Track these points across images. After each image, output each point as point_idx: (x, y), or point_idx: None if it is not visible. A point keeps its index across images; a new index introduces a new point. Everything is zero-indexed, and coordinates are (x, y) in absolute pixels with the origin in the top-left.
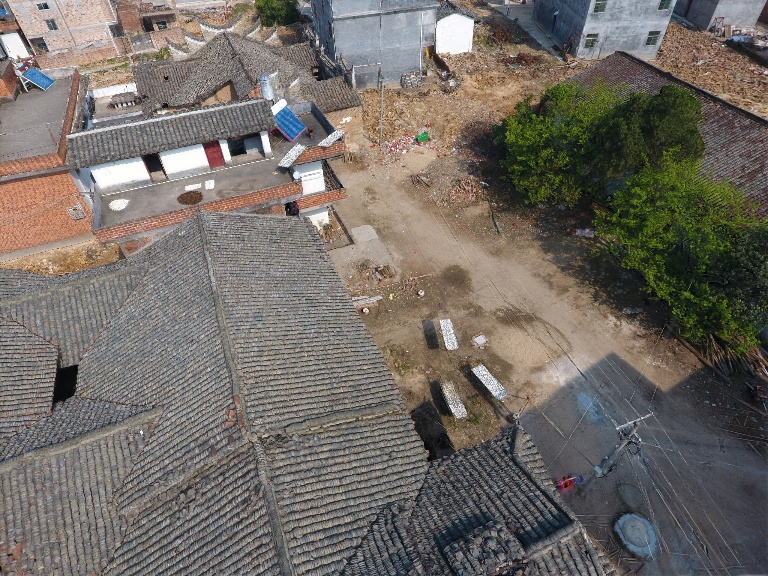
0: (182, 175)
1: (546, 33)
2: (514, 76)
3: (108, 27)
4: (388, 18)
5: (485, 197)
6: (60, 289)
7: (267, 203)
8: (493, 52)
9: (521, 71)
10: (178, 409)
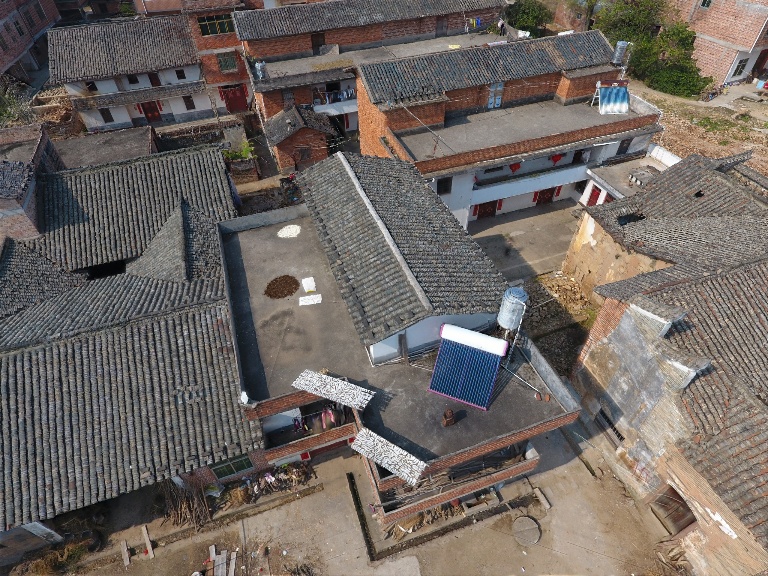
0: None
1: None
2: None
3: None
4: None
5: None
6: None
7: None
8: None
9: None
10: None
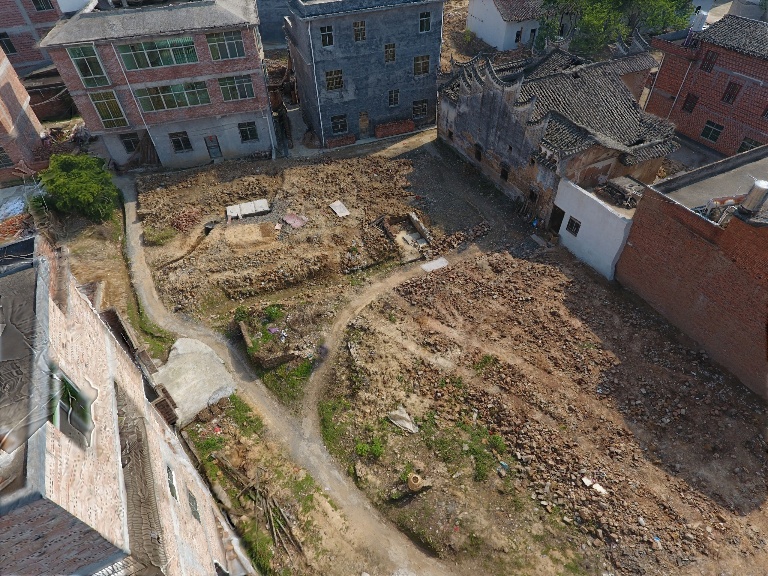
0: None
1: None
2: None
3: None
4: None
5: None
6: None
7: None
8: None
9: None
10: None
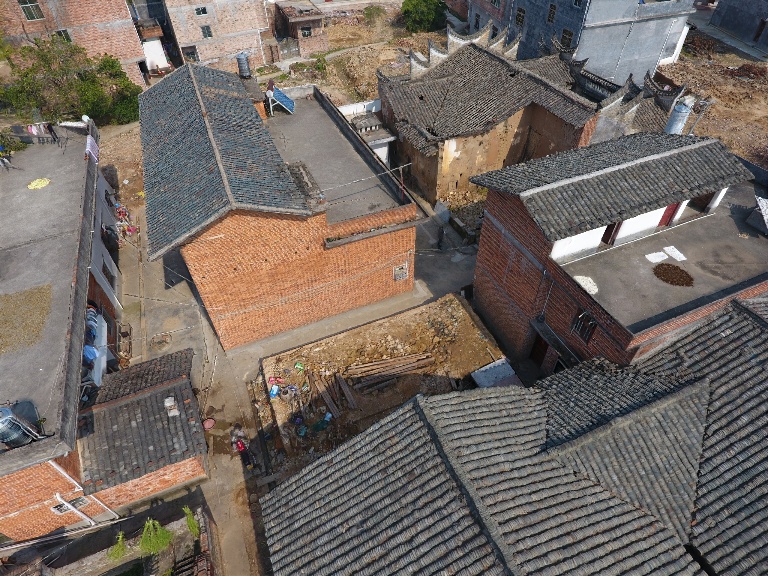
0: (627, 239)
1: (743, 41)
2: (759, 91)
3: (259, 34)
4: (638, 26)
5: None
6: (620, 425)
7: None
8: (703, 63)
9: (761, 85)
10: None
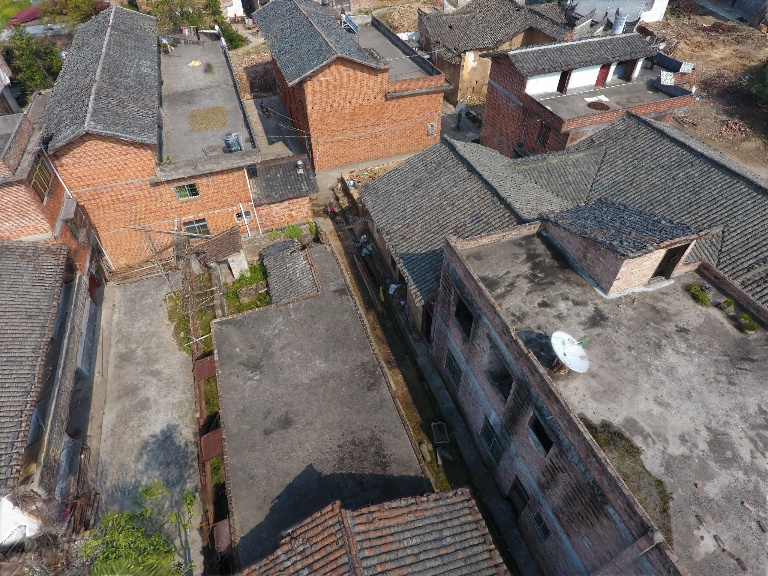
0: (575, 91)
1: (723, 7)
2: (721, 41)
3: None
4: None
5: (754, 135)
6: (551, 161)
7: (666, 111)
8: (684, 22)
9: (724, 37)
10: (739, 225)
